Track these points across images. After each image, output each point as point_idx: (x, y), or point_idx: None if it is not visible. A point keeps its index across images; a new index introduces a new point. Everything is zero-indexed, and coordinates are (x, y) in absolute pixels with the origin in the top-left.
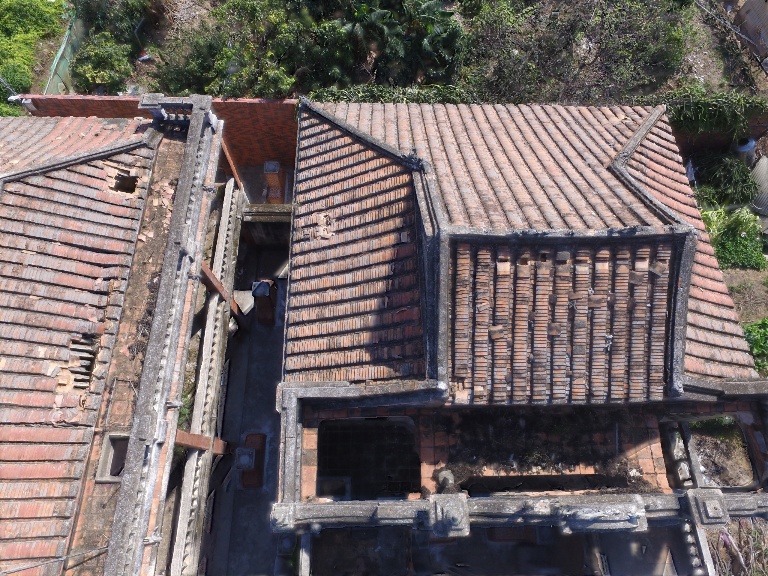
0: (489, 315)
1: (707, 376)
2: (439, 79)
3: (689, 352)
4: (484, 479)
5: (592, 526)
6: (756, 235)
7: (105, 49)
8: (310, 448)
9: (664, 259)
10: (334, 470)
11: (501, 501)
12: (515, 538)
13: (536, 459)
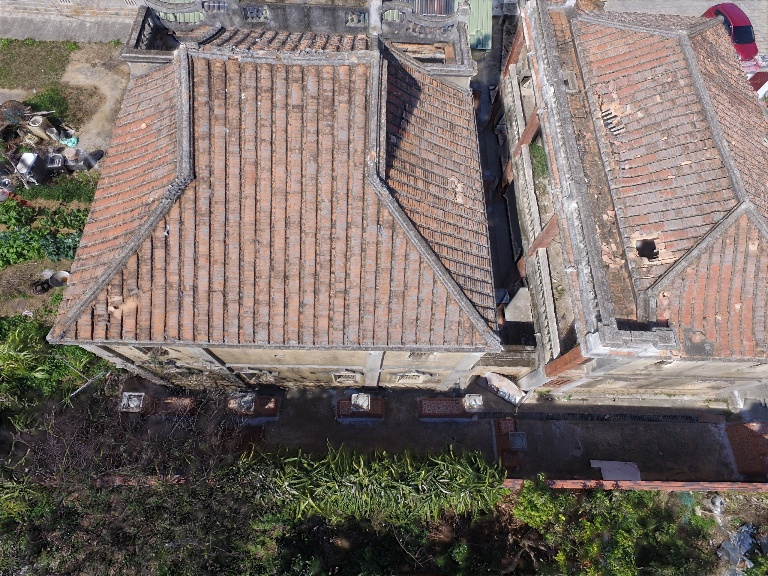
0: None
1: None
2: (301, 554)
3: None
4: None
5: None
6: None
7: None
8: None
9: None
10: None
11: None
12: None
13: None
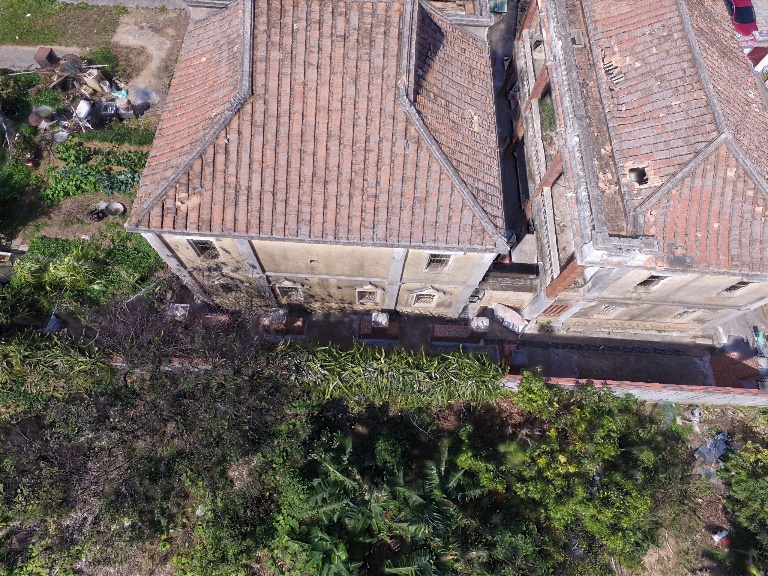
0: None
1: None
2: (329, 429)
3: None
4: None
5: None
6: None
7: (767, 494)
8: None
9: None
10: None
11: None
12: None
13: None
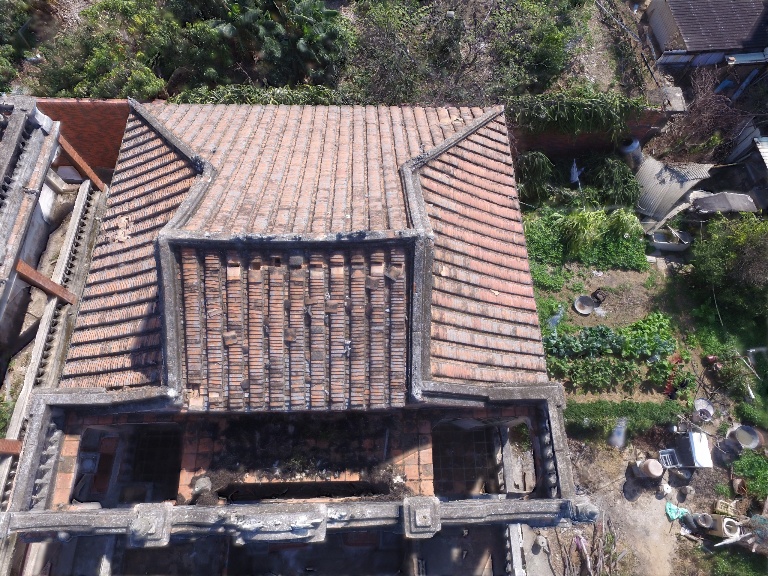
0: (223, 321)
1: (475, 381)
2: (319, 79)
3: (454, 357)
4: (247, 486)
5: (255, 537)
6: (640, 236)
7: None
8: (69, 455)
9: (398, 264)
10: (147, 475)
11: (207, 510)
12: (368, 542)
13: (296, 466)
